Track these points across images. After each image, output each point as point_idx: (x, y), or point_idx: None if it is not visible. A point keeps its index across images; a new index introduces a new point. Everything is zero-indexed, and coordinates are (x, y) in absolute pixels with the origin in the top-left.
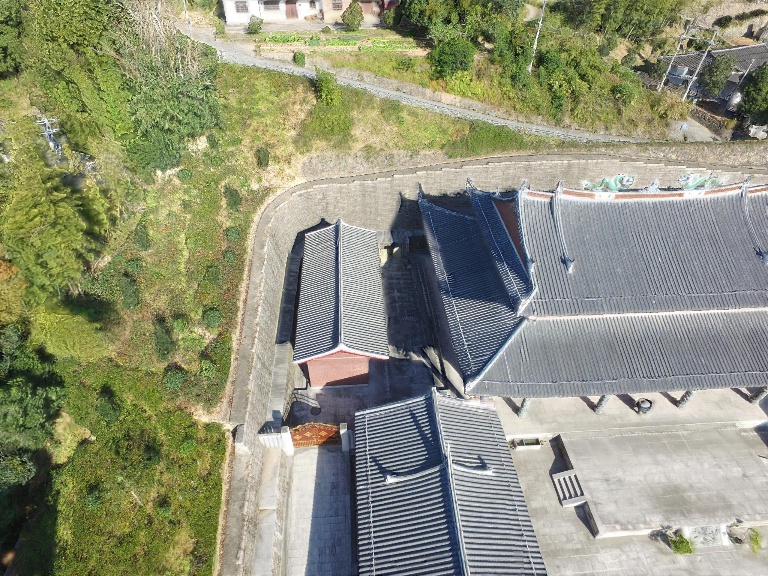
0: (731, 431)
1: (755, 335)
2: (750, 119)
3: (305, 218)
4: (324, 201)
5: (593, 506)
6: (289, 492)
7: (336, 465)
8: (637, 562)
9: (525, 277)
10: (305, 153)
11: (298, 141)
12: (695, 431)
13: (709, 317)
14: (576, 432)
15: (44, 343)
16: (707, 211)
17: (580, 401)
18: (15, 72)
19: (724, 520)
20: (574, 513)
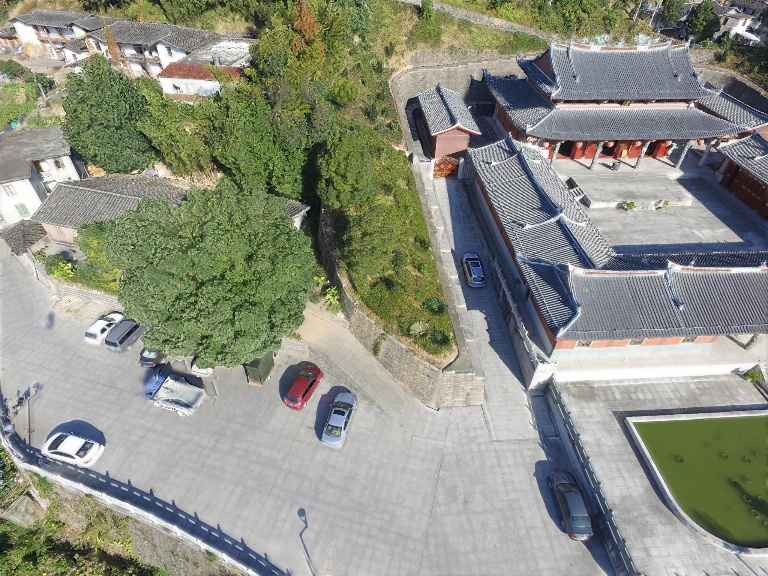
0: (663, 177)
1: (673, 119)
2: (694, 40)
3: (412, 90)
4: (424, 80)
5: (588, 196)
6: (435, 191)
7: (456, 183)
8: (609, 214)
9: (554, 85)
10: (413, 50)
11: (409, 42)
12: (643, 177)
13: (650, 111)
14: (580, 176)
15: (338, 92)
16: (649, 57)
17: (582, 166)
18: (214, 6)
19: (653, 200)
20: (579, 202)
